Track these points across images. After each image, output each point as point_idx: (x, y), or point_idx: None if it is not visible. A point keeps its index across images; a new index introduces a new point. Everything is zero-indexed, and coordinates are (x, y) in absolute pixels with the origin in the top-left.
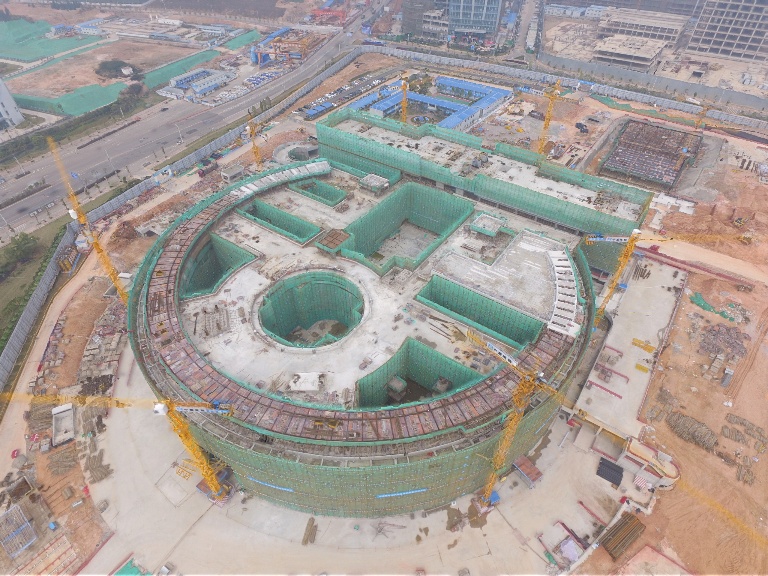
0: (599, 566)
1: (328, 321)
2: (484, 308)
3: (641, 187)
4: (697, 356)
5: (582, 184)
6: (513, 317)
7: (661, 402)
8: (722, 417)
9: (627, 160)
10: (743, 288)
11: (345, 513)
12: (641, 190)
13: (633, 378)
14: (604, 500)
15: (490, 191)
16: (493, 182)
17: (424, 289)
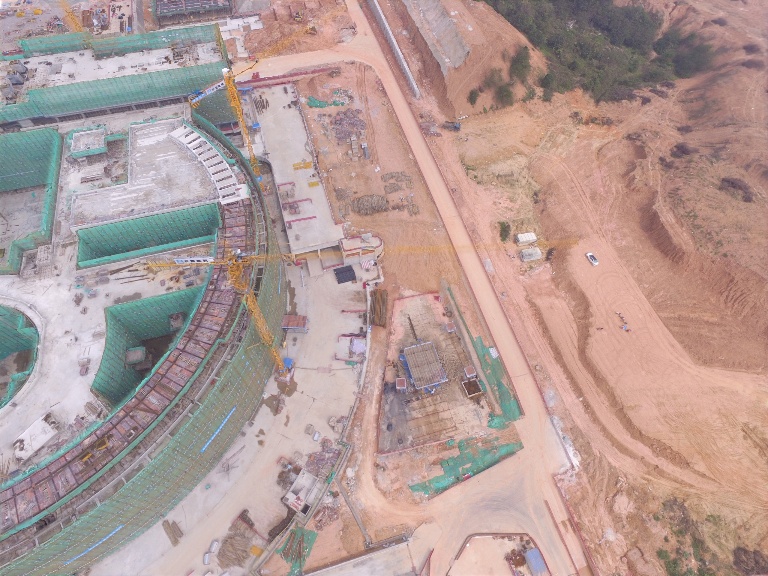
0: (380, 339)
1: (4, 361)
2: (156, 227)
3: (207, 21)
4: (340, 148)
5: (149, 46)
6: (188, 216)
7: (341, 200)
8: (380, 181)
9: None
10: (334, 74)
11: (188, 489)
12: (205, 26)
13: (313, 196)
14: (354, 296)
15: (60, 104)
16: (54, 92)
17: (80, 252)
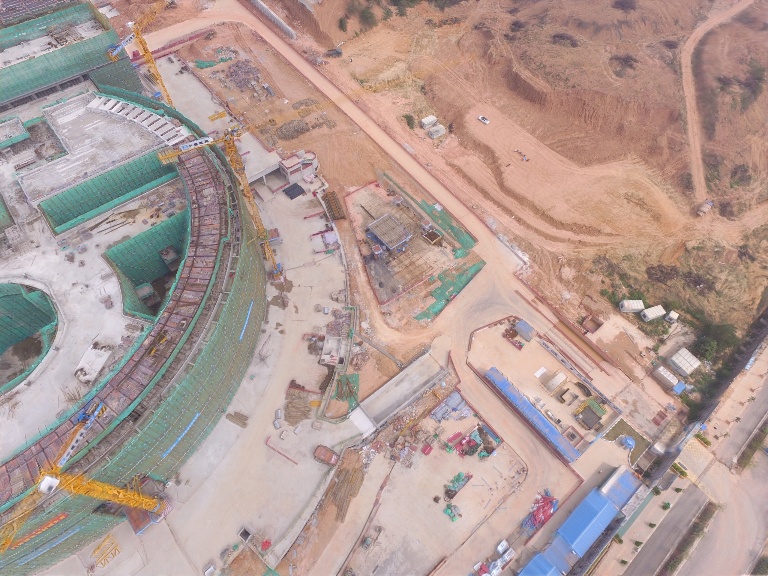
0: (345, 228)
1: (1, 358)
2: (113, 184)
3: None
4: (245, 94)
5: (26, 37)
6: (141, 166)
7: (265, 133)
8: (292, 110)
9: (14, 5)
10: (211, 35)
11: (237, 382)
12: None
13: None
14: (310, 205)
15: None
16: None
17: (50, 222)
